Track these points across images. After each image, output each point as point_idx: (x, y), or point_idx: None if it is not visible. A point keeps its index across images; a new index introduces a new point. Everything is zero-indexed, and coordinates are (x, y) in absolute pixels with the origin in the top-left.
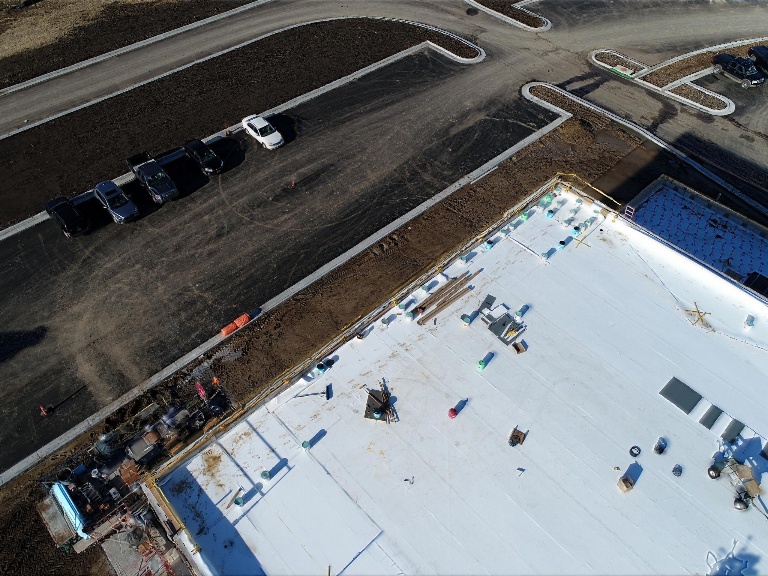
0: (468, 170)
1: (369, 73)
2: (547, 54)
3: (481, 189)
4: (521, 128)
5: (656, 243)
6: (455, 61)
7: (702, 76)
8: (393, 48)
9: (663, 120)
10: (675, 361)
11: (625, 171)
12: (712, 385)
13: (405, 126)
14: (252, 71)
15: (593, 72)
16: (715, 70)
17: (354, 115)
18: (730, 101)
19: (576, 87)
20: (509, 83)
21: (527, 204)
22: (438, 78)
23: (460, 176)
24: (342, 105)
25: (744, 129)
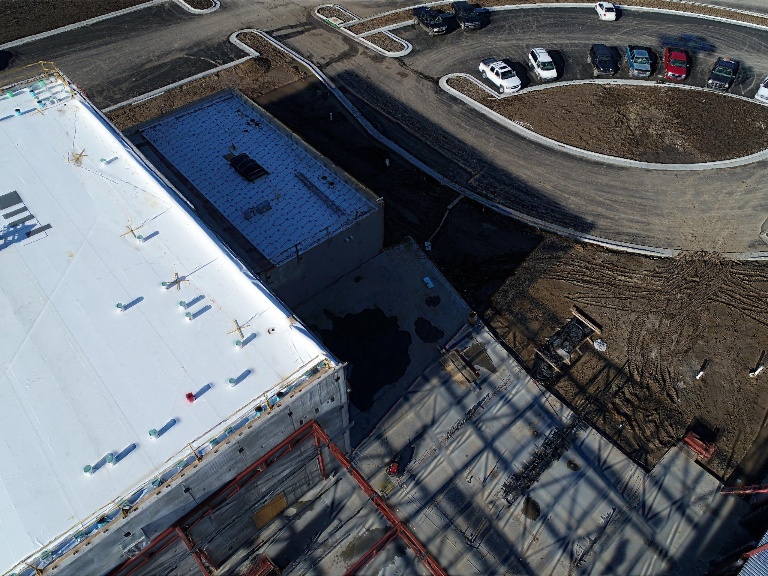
0: (137, 95)
1: (104, 20)
2: (276, 7)
3: (137, 109)
4: (207, 64)
5: (86, 110)
6: (188, 12)
7: (402, 26)
8: (138, 0)
9: (339, 60)
10: (27, 182)
11: (272, 97)
12: (38, 196)
13: (107, 61)
14: (0, 17)
15: (307, 22)
16: (415, 21)
17: (68, 52)
18: (410, 46)
19: (282, 33)
20: (224, 29)
21: (14, 85)
22: (163, 25)
23: (126, 99)
24: (63, 44)
25: (405, 68)
